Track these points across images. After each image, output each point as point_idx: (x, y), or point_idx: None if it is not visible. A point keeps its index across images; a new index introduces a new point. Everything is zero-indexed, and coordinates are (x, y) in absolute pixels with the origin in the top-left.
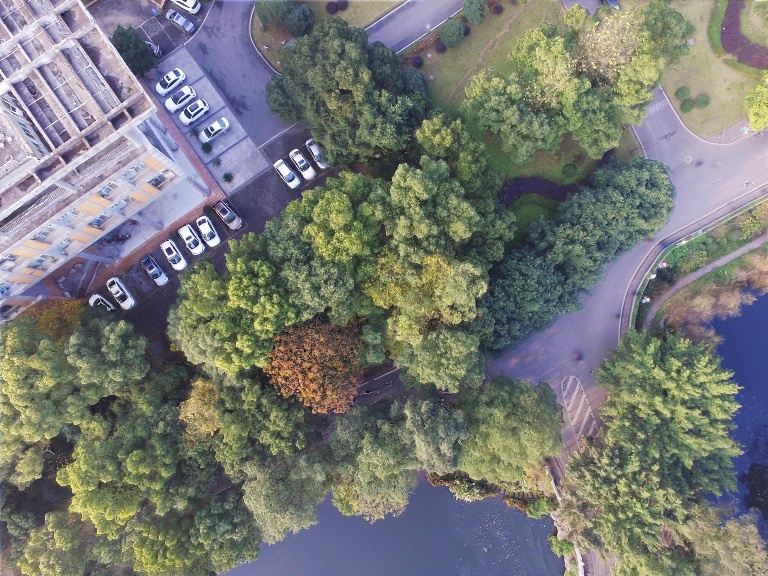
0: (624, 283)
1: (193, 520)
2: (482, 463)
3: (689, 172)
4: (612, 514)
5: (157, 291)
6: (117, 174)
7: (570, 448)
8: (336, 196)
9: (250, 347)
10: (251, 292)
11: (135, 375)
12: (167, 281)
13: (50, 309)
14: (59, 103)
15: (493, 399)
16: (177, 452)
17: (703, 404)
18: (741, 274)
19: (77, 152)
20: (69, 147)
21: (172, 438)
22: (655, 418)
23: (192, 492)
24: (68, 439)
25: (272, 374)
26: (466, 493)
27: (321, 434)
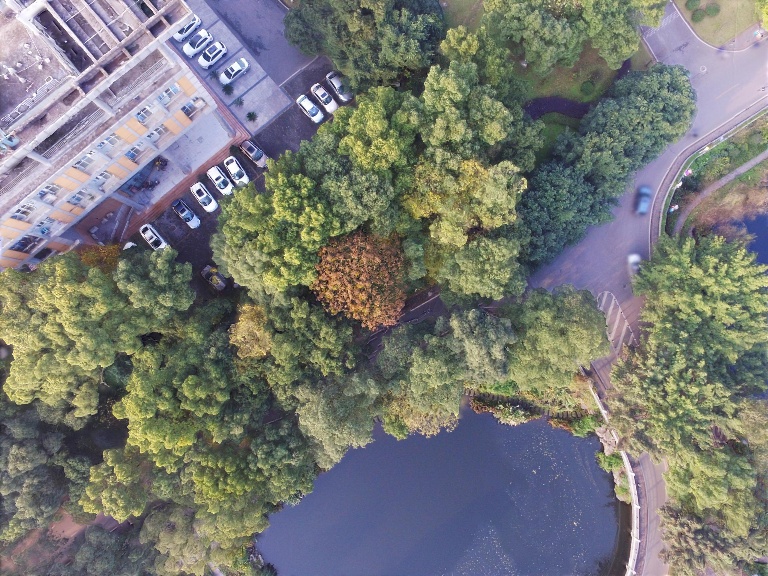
0: (650, 196)
1: (249, 450)
2: (531, 369)
3: (705, 81)
4: (662, 413)
5: (190, 235)
6: (154, 95)
7: (610, 363)
8: (370, 105)
9: (298, 259)
10: (296, 203)
11: (183, 302)
12: (200, 224)
13: (89, 253)
14: (96, 16)
15: (537, 305)
16: (230, 378)
17: (742, 300)
18: (767, 171)
19: (118, 63)
20: (110, 59)
21: (224, 364)
22: (696, 317)
23: (247, 419)
24: (117, 380)
25: (319, 291)
26: (511, 416)
27: (367, 358)
